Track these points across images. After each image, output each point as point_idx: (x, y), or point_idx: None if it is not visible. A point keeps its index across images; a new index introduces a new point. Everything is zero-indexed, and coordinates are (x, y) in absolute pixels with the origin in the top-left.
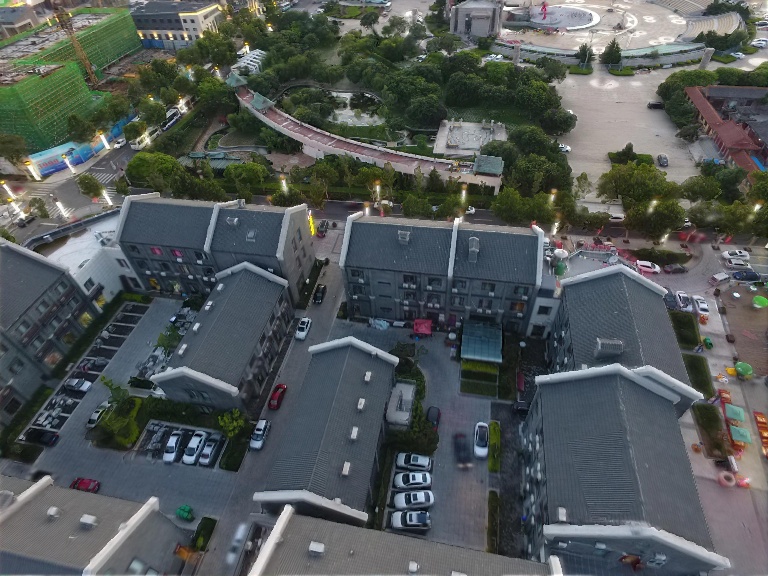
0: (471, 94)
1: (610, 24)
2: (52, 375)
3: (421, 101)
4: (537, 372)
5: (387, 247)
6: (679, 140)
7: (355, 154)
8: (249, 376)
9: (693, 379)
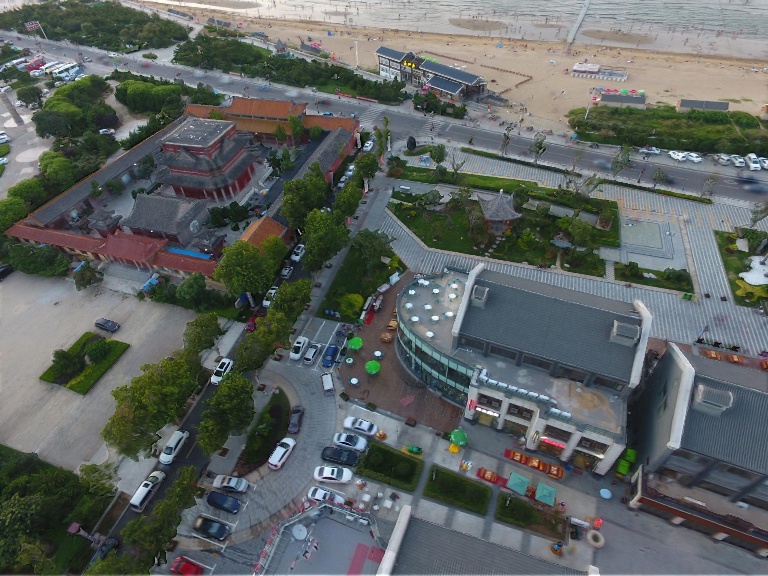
0: None
1: None
2: None
3: None
4: None
5: None
6: None
7: None
8: None
9: (466, 499)
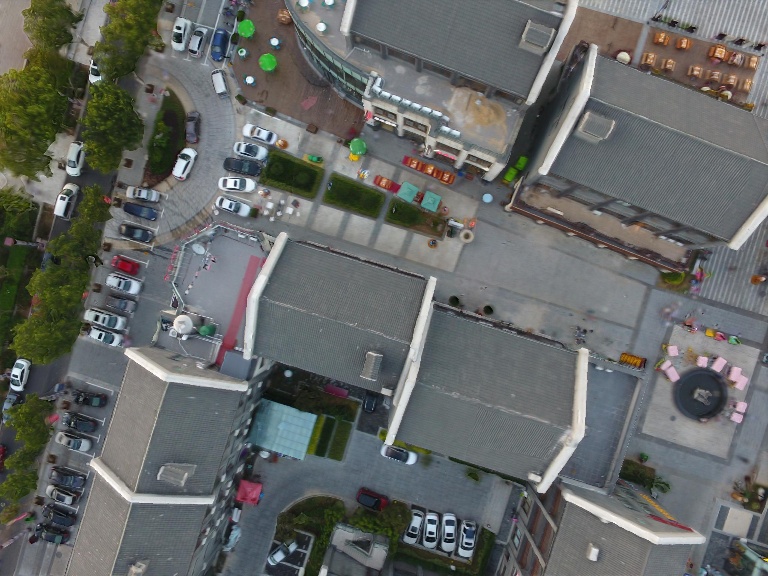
0: None
1: None
2: None
3: None
4: None
5: None
6: None
7: None
8: None
9: (360, 205)
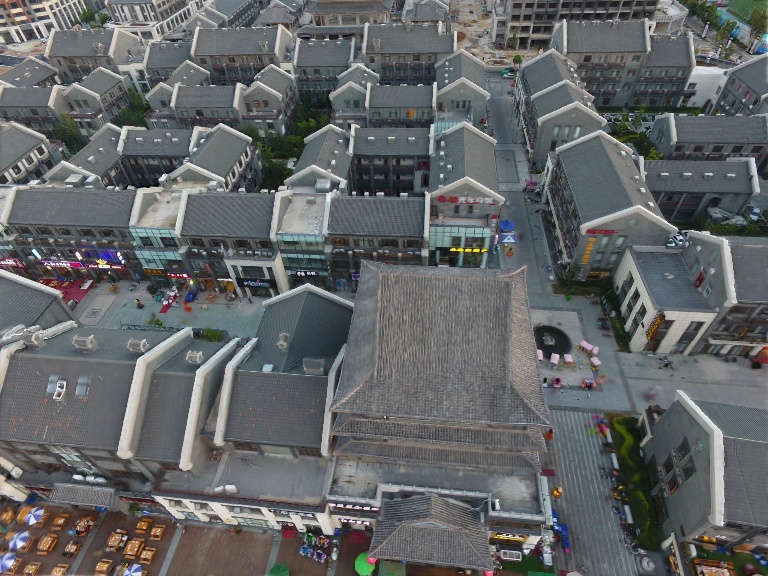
0: None
1: None
2: (629, 108)
3: None
4: None
5: None
6: None
7: None
8: (688, 152)
9: None
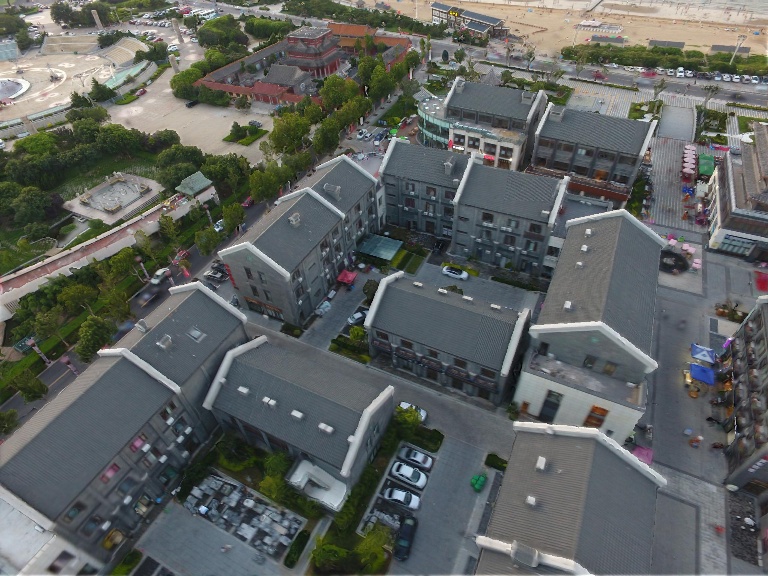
0: (50, 172)
1: (42, 80)
2: None
3: (24, 199)
4: (411, 235)
5: (293, 238)
6: (239, 112)
7: (59, 271)
8: None
9: None
